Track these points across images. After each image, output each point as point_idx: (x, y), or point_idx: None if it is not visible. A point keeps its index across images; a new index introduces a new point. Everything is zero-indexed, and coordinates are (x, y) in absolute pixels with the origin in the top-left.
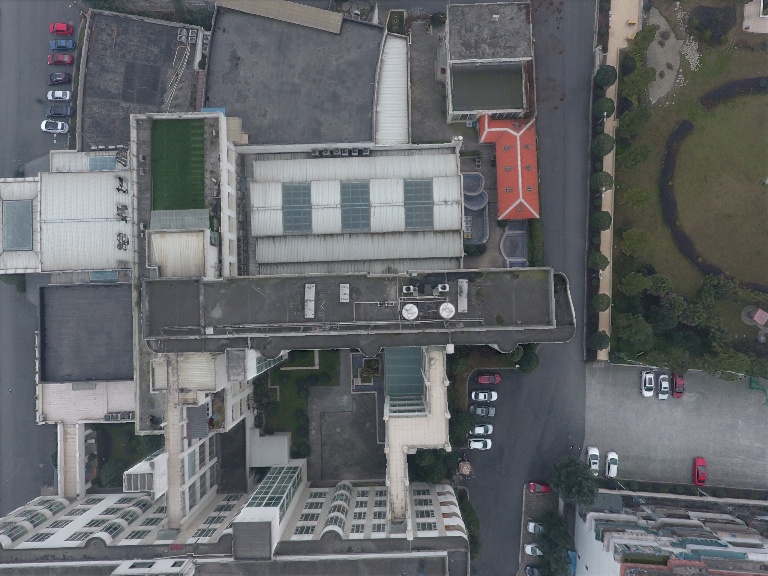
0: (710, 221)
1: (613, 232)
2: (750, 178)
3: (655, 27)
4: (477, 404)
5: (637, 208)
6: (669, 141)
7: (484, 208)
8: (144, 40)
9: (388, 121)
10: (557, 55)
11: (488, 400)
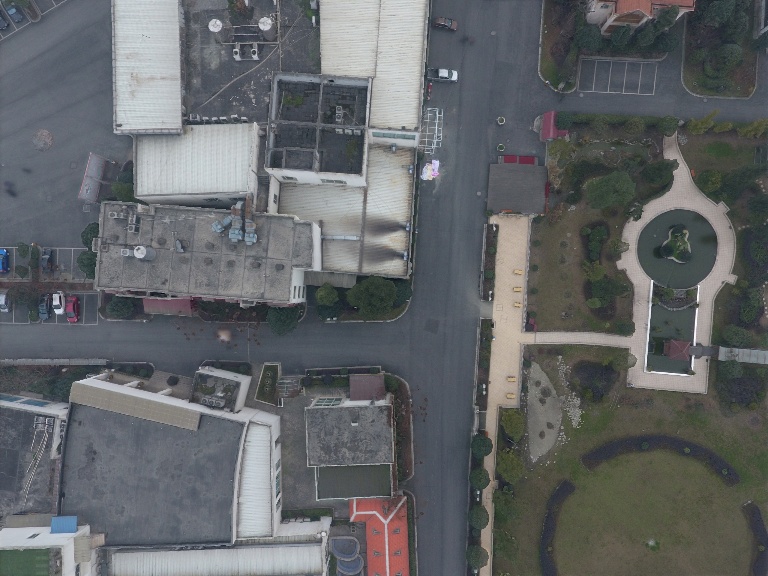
0: None
1: None
2: (633, 539)
3: (520, 430)
4: None
5: (517, 571)
6: (549, 503)
7: (360, 572)
8: (1, 423)
9: (251, 512)
10: (436, 411)
11: None
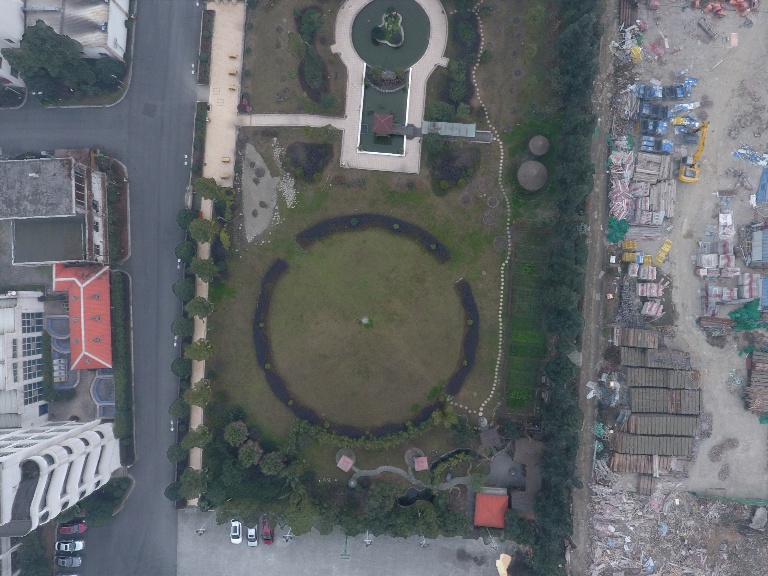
0: (306, 362)
1: (205, 375)
2: (347, 317)
3: (199, 182)
4: (63, 553)
5: (231, 349)
6: (263, 281)
7: None
8: None
9: None
10: (153, 193)
11: (71, 551)
